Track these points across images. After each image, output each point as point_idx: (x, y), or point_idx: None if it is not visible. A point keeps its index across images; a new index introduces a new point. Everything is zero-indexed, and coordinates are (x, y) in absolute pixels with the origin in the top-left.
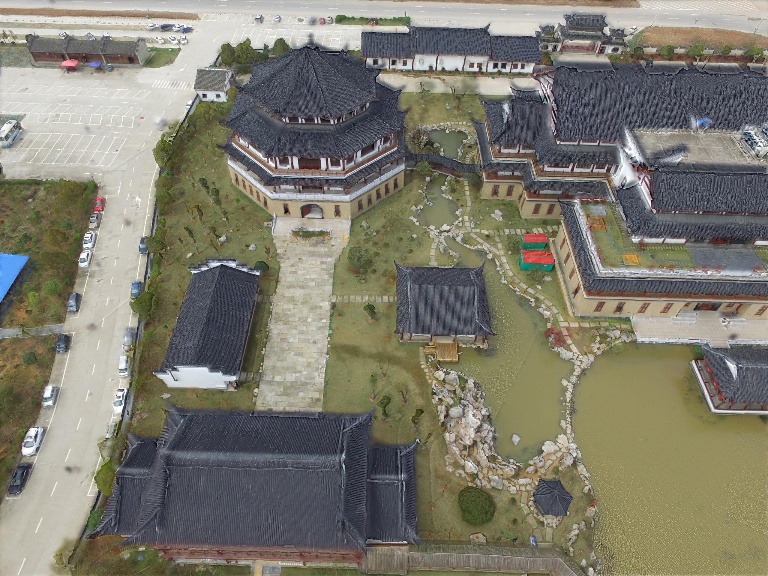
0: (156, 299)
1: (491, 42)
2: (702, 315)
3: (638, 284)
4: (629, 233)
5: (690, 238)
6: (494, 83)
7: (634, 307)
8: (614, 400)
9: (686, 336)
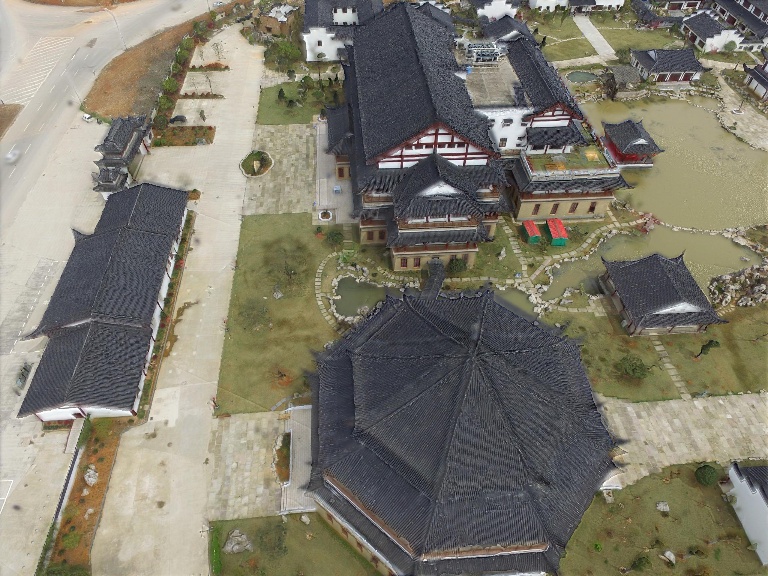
0: None
1: None
2: None
3: None
4: (586, 145)
5: None
6: (206, 249)
7: None
8: None
9: None
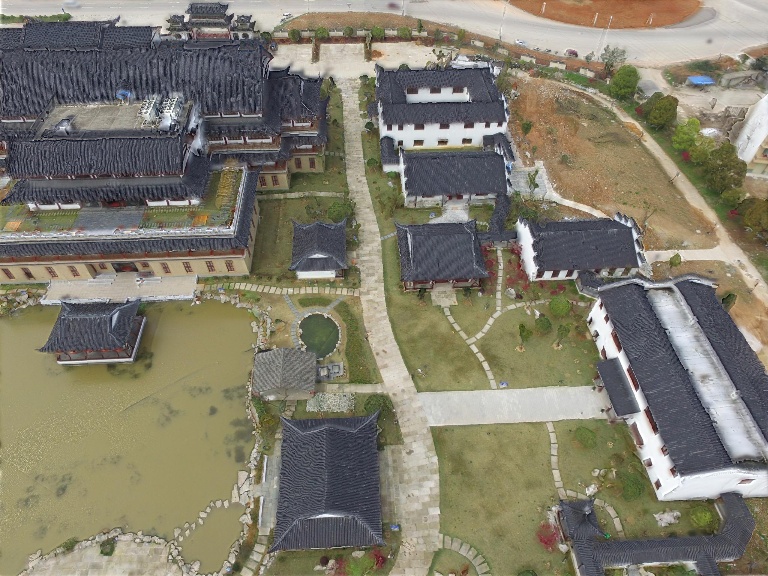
0: None
1: (104, 33)
2: (122, 276)
3: (10, 248)
4: (1, 201)
5: (60, 202)
6: None
7: (41, 272)
8: (2, 361)
9: (92, 296)
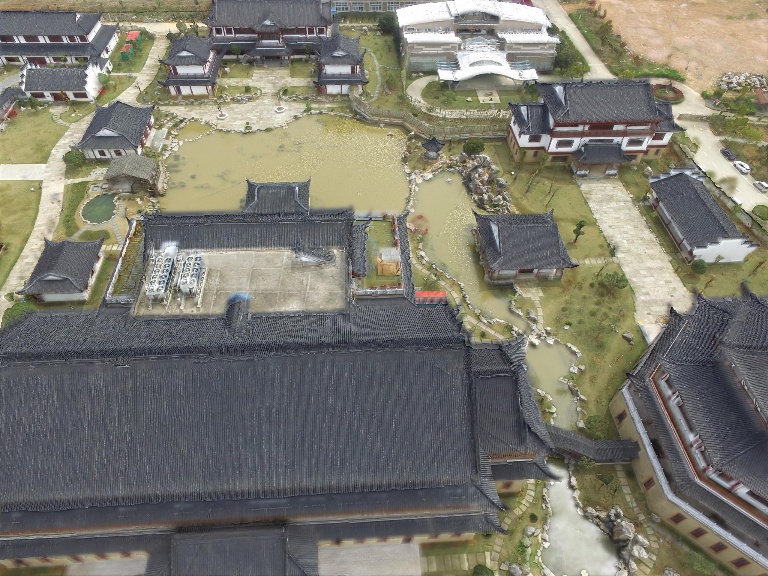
0: (766, 250)
1: None
2: None
3: None
4: None
5: None
6: None
7: None
8: None
9: None
